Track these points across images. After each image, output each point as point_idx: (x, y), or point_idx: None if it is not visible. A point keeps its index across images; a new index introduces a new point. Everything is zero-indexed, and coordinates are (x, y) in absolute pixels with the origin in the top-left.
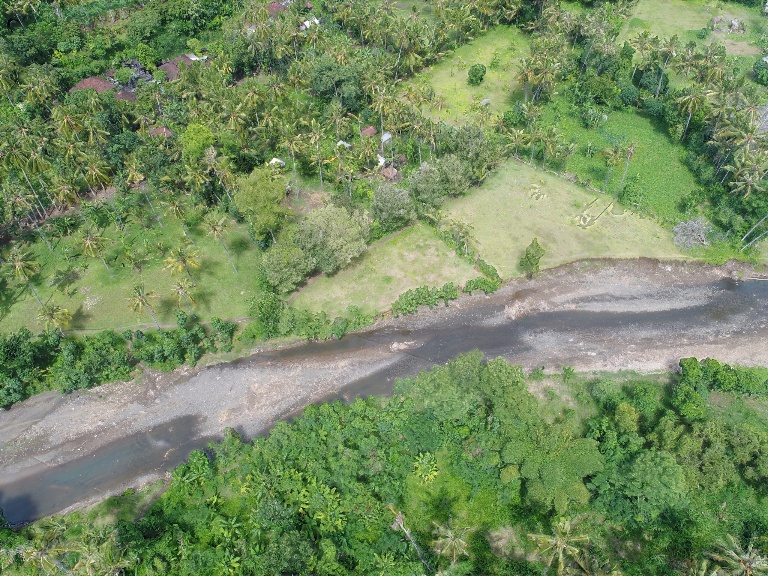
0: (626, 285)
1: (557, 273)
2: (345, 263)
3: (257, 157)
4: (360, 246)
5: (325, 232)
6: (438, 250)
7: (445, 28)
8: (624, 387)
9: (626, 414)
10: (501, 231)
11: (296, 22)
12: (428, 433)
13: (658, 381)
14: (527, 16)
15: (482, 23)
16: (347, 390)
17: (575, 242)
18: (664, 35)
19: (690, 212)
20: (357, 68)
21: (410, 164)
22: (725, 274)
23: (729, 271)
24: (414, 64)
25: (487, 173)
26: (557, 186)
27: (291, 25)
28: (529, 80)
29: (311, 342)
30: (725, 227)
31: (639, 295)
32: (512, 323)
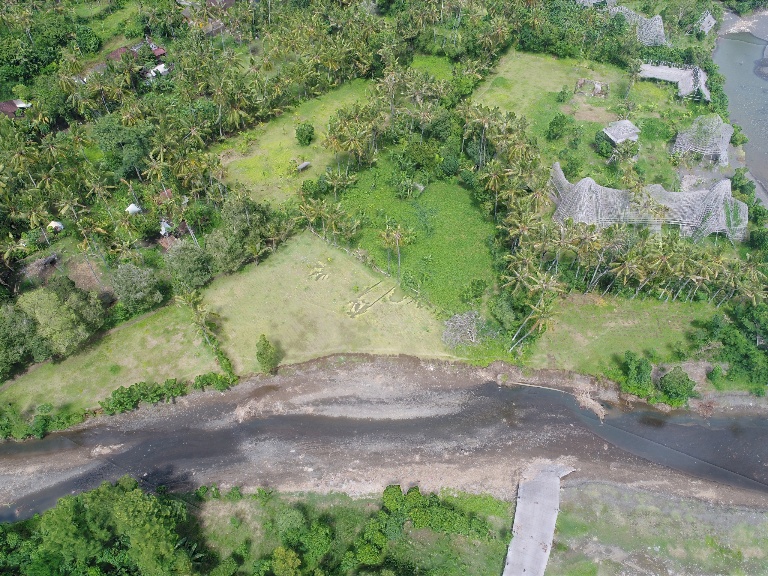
0: (378, 386)
1: (307, 368)
2: (69, 350)
3: (29, 221)
4: (77, 335)
5: (32, 319)
6: (185, 336)
7: (279, 84)
8: (322, 515)
9: (278, 562)
10: (263, 316)
11: (130, 71)
12: (52, 574)
13: (366, 508)
14: (377, 72)
15: (332, 77)
16: (22, 503)
17: (336, 333)
18: (523, 96)
19: (473, 302)
20: (142, 130)
21: (197, 233)
22: (490, 377)
23: (496, 373)
24: (237, 121)
25: (264, 249)
26: (343, 265)
27: (94, 79)
28: (333, 148)
29: (9, 441)
30: (502, 322)
31: (388, 399)
32: (237, 427)
